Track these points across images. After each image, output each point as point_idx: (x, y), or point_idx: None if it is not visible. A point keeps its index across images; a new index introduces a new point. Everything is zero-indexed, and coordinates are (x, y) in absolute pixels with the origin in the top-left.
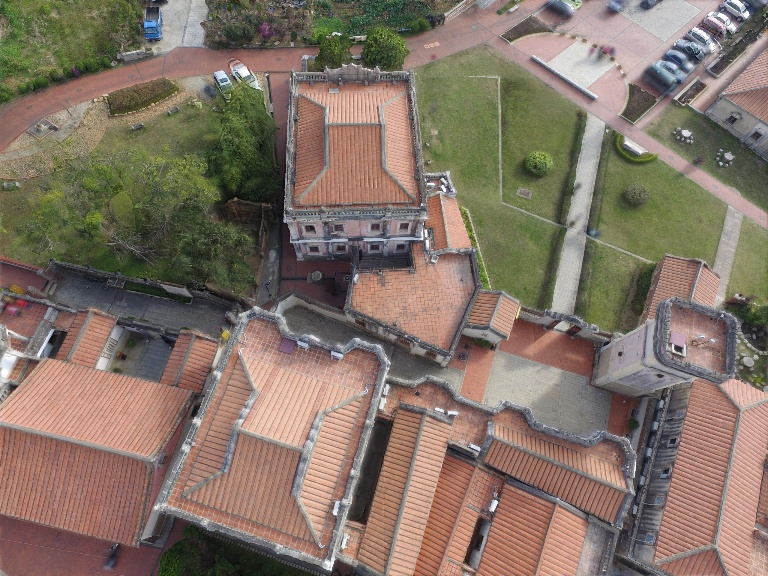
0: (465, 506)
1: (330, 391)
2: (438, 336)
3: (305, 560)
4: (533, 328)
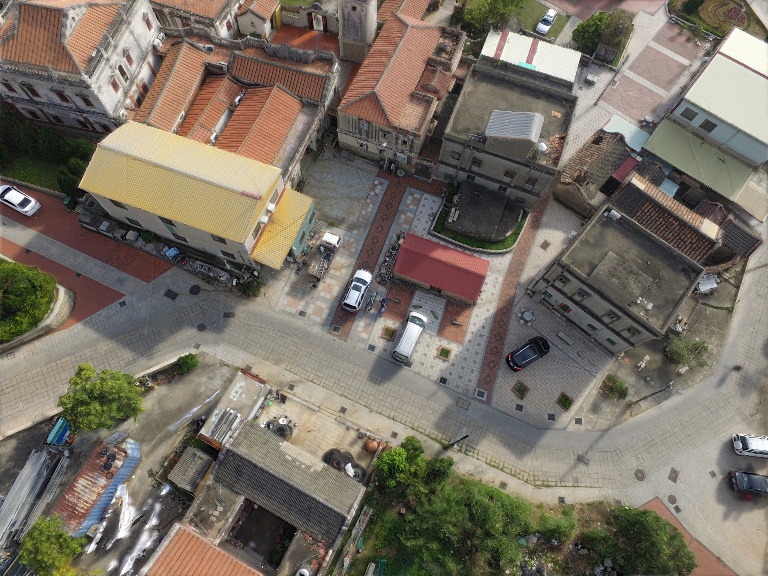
0: (215, 98)
1: (98, 1)
2: (209, 15)
3: (70, 76)
4: (299, 30)
